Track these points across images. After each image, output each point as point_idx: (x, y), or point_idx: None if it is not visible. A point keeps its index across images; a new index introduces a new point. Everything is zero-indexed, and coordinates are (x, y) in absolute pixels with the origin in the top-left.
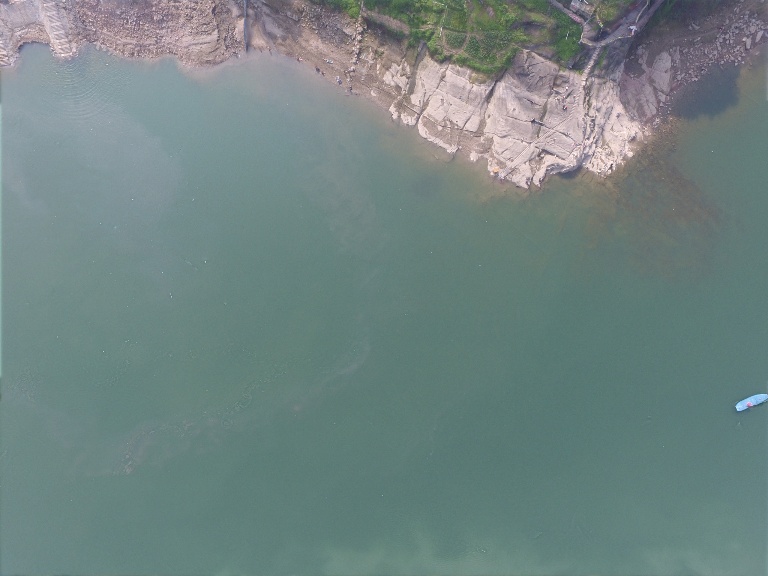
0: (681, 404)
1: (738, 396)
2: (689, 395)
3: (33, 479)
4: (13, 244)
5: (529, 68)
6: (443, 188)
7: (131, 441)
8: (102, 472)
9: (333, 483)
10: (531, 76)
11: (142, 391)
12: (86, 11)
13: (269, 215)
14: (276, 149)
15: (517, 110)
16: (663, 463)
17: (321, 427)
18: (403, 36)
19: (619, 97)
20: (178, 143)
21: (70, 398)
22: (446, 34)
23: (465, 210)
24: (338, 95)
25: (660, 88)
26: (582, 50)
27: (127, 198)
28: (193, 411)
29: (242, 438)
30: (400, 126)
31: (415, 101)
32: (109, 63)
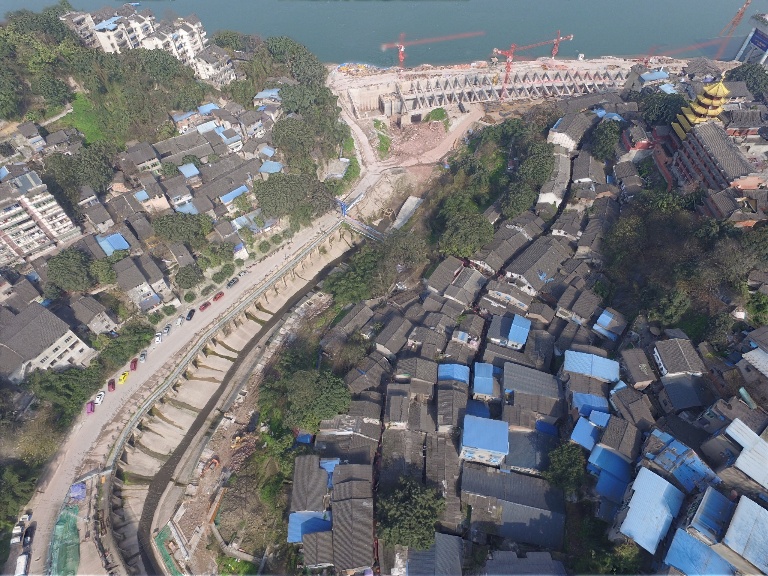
0: None
1: None
2: (155, 8)
3: None
4: None
5: None
6: None
7: None
8: None
9: None
10: None
11: (366, 4)
12: None
13: (306, 34)
14: None
15: None
16: None
17: None
18: None
19: None
20: None
21: None
22: None
23: None
24: None
25: None
26: None
27: None
28: None
29: None
30: None
31: None
32: None
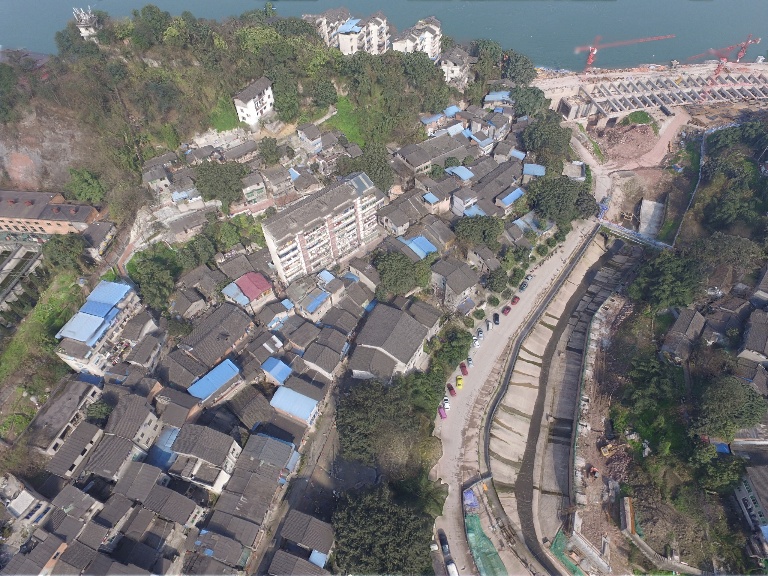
0: None
1: None
2: None
3: None
4: None
5: None
6: None
7: None
8: None
9: None
10: None
11: (503, 8)
12: None
13: None
14: None
15: None
16: None
17: None
18: None
19: None
20: None
21: (532, 5)
22: None
23: None
24: None
25: None
26: None
27: (521, 40)
28: None
29: None
30: None
31: None
32: None
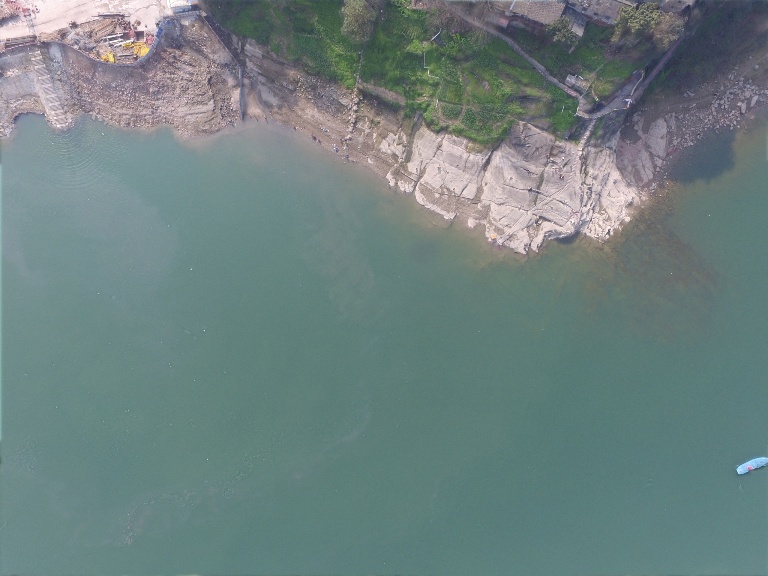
0: (682, 467)
1: (739, 459)
2: (690, 458)
3: (34, 549)
4: (11, 315)
5: (525, 139)
6: (441, 254)
7: (132, 512)
8: (103, 542)
9: (335, 551)
10: (527, 146)
11: (142, 461)
12: (81, 83)
13: (267, 283)
14: (274, 217)
15: (514, 179)
16: (665, 526)
17: (323, 495)
18: (399, 107)
19: (615, 163)
20: (175, 212)
21: (70, 469)
22: (442, 106)
23: (463, 276)
24: (335, 163)
25: (656, 153)
26: (578, 122)
27: (125, 268)
28: (194, 480)
29: (243, 507)
30: (397, 193)
31: (412, 169)
32: (105, 133)
